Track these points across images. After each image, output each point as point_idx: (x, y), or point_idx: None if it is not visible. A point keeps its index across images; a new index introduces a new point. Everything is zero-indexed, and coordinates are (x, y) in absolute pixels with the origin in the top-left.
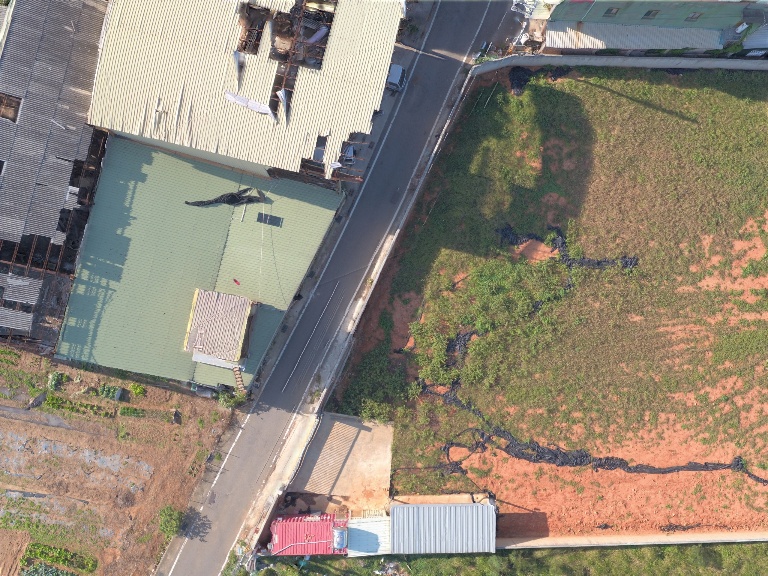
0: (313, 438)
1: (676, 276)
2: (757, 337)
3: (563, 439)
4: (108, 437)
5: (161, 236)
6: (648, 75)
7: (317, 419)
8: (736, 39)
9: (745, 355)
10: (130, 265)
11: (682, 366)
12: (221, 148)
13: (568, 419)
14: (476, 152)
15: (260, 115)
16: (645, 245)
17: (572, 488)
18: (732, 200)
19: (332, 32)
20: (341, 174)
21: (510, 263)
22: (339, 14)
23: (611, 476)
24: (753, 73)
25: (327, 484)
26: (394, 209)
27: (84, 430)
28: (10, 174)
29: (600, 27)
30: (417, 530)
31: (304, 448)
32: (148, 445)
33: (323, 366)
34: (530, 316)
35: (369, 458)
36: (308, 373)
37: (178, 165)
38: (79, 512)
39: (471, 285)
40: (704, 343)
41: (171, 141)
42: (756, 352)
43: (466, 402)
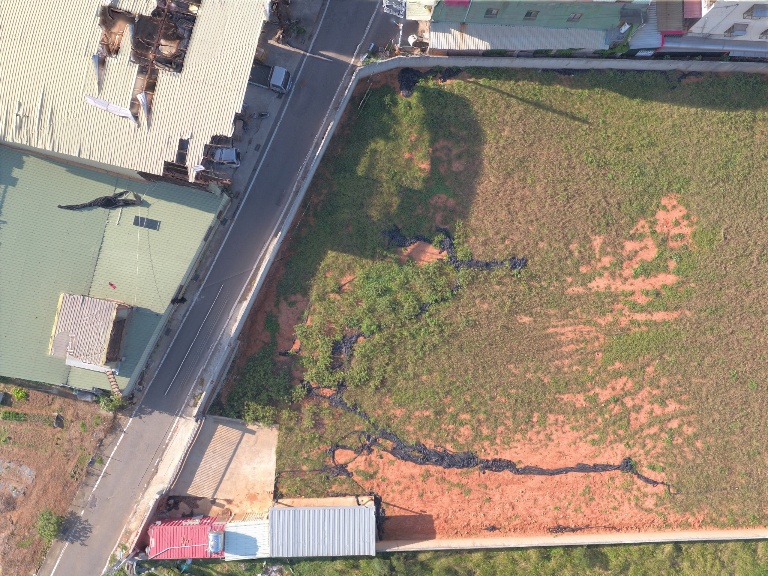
0: (195, 441)
1: (566, 277)
2: (647, 338)
3: (450, 441)
4: None
5: (33, 240)
6: (539, 76)
7: (197, 422)
8: (620, 39)
9: (635, 356)
10: (0, 269)
11: (571, 367)
12: (83, 152)
13: (455, 421)
14: (363, 154)
15: (121, 118)
16: (534, 246)
17: (459, 490)
18: (623, 200)
19: (193, 35)
20: (209, 177)
21: (397, 265)
22: (201, 17)
23: (499, 478)
24: (645, 73)
25: (210, 487)
26: (280, 211)
27: None
28: None
29: (484, 28)
30: (296, 533)
31: (184, 451)
32: (30, 449)
33: (206, 369)
34: (417, 318)
35: (253, 461)
36: (191, 376)
37: (50, 169)
38: None
39: (358, 287)
40: (594, 344)
41: (33, 145)
42: (646, 353)
43: (352, 404)
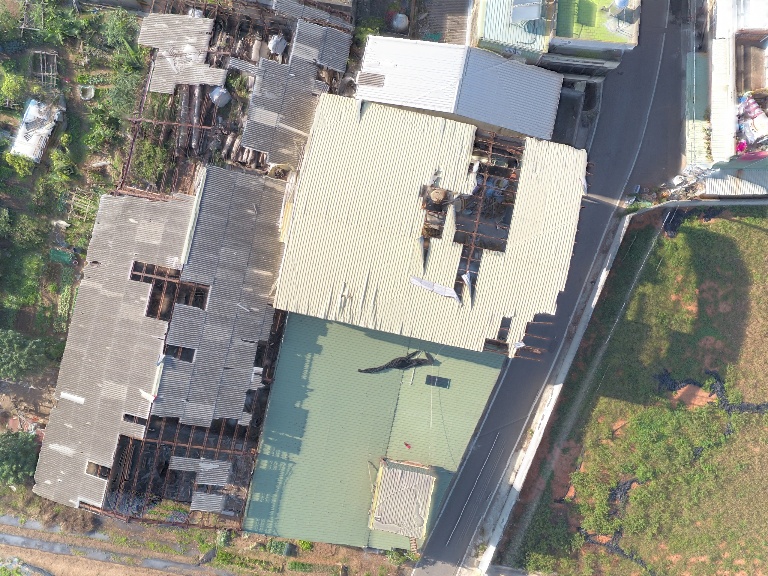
0: None
1: None
2: None
3: None
4: None
5: (336, 405)
6: None
7: None
8: None
9: None
10: (308, 437)
11: None
12: (405, 330)
13: (731, 567)
14: (632, 298)
15: (445, 298)
16: None
17: None
18: None
19: (515, 213)
20: None
21: (669, 410)
22: (521, 194)
23: None
24: None
25: None
26: (552, 358)
27: None
28: (200, 361)
29: (761, 173)
30: None
31: None
32: None
33: (486, 519)
34: (691, 463)
35: None
36: (471, 526)
37: (351, 334)
38: None
39: (630, 433)
40: None
41: (355, 323)
42: None
43: (628, 552)
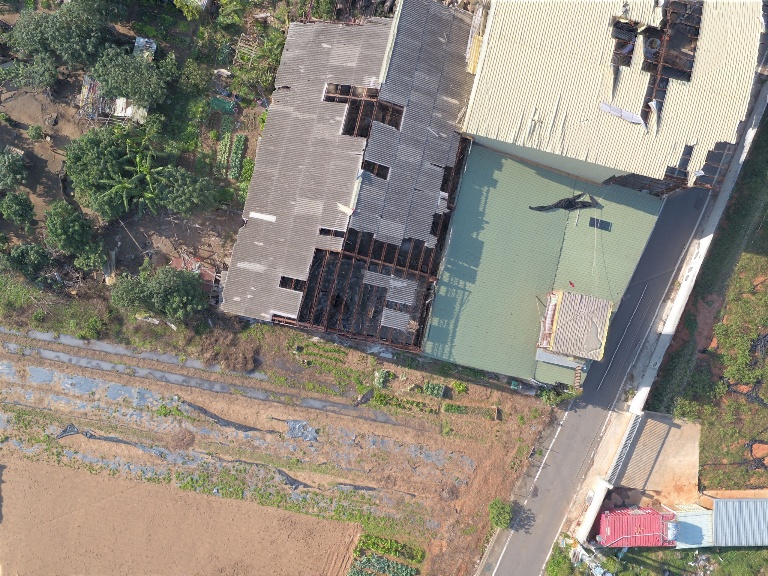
0: None
1: None
2: None
3: None
4: (433, 433)
5: (509, 240)
6: None
7: None
8: None
9: None
10: (483, 267)
11: None
12: (590, 156)
13: None
14: None
15: (631, 125)
16: None
17: None
18: None
19: (699, 45)
20: None
21: None
22: (704, 28)
23: None
24: None
25: (641, 479)
26: (697, 214)
27: (410, 426)
28: (394, 180)
29: None
30: (739, 523)
31: (627, 444)
32: (471, 441)
33: (635, 365)
34: None
35: (679, 454)
36: (621, 372)
37: (523, 171)
38: (407, 505)
39: None
40: None
41: (542, 149)
42: None
43: None
